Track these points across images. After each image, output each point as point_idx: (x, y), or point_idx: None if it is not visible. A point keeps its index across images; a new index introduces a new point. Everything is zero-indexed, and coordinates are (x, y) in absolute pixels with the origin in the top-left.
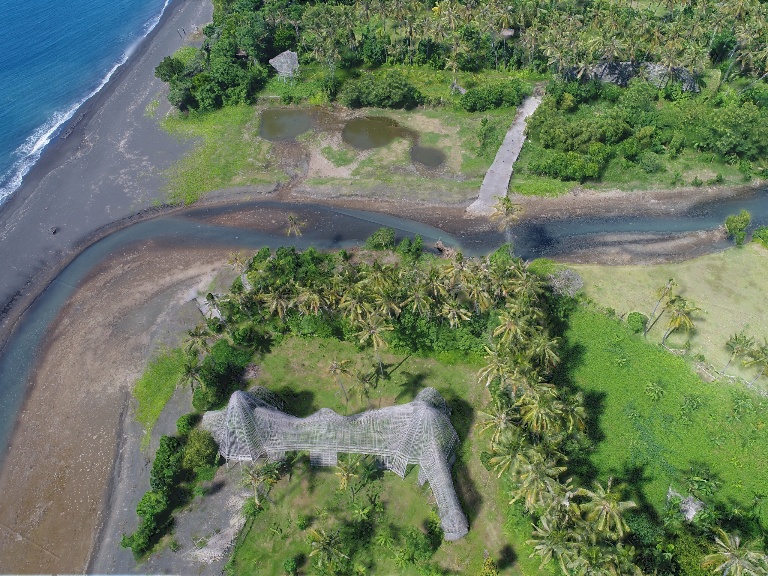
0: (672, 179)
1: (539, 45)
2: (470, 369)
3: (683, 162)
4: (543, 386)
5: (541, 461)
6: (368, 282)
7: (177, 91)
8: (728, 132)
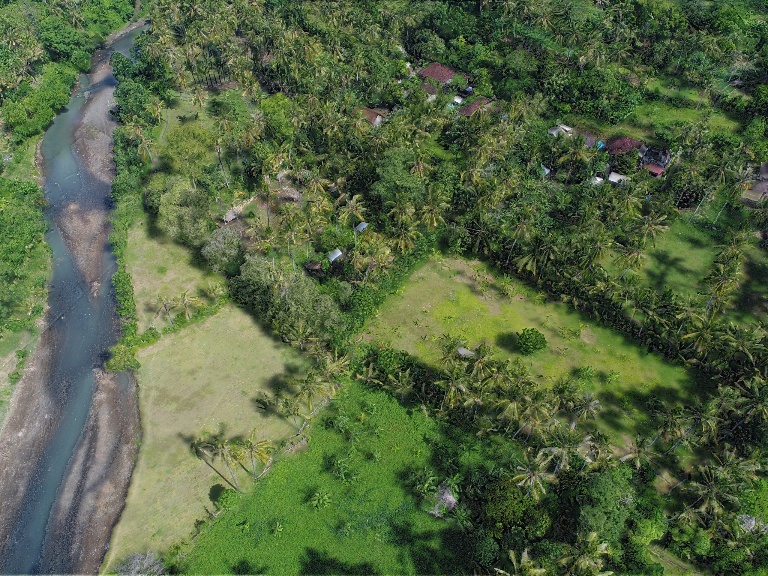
0: None
1: None
2: None
3: None
4: None
5: None
6: None
7: None
8: None
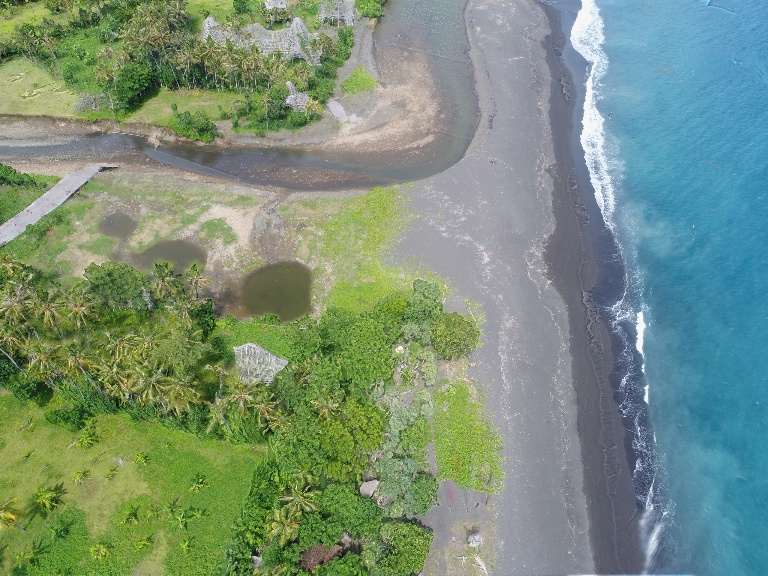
0: None
1: None
2: None
3: None
4: (151, 7)
5: None
6: None
7: None
8: None
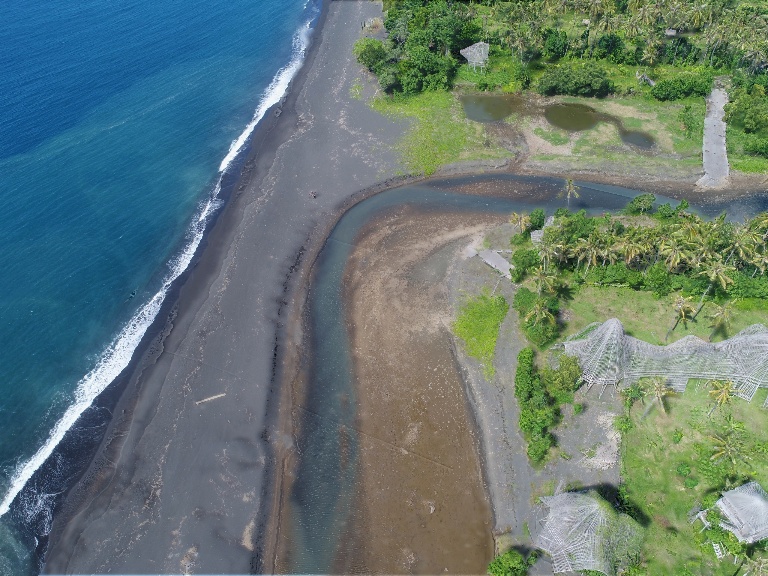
0: None
1: (722, 42)
2: (767, 314)
3: None
4: None
5: None
6: (683, 233)
7: (387, 75)
8: None
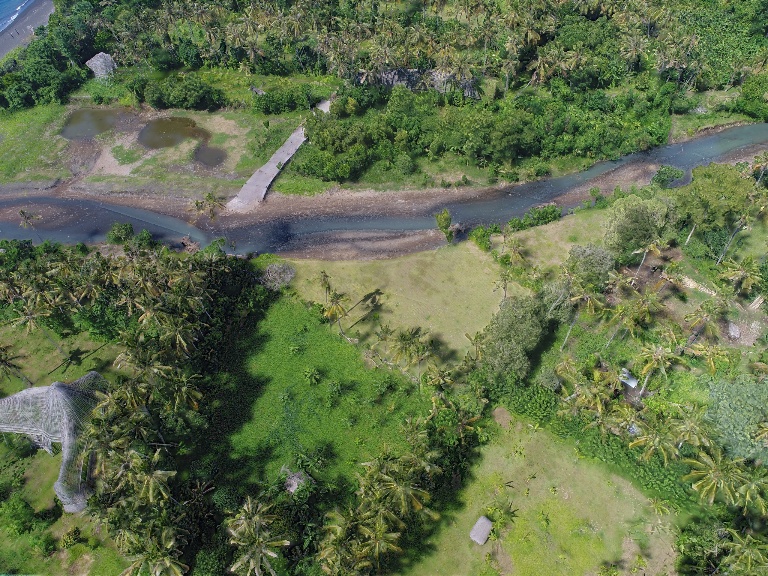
0: (421, 180)
1: None
2: None
3: (441, 165)
4: (155, 368)
5: (95, 434)
6: (55, 272)
7: None
8: (470, 136)
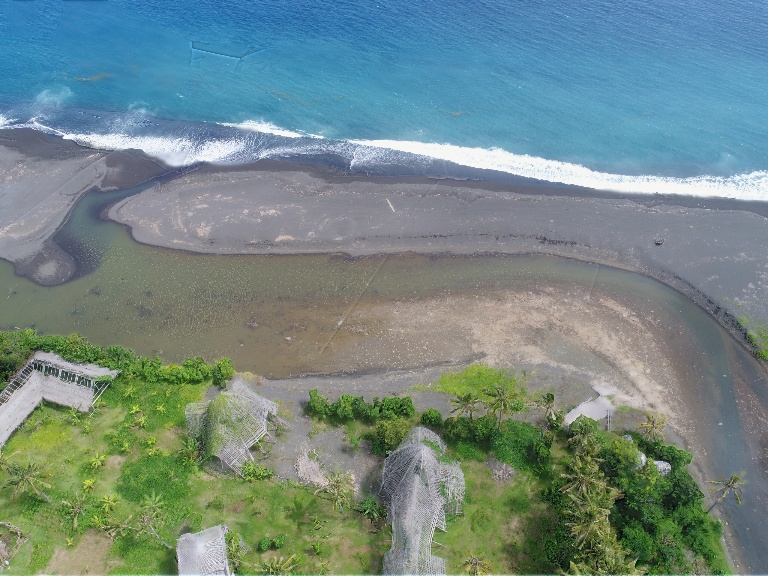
0: None
1: None
2: None
3: None
4: None
5: None
6: None
7: None
8: None
